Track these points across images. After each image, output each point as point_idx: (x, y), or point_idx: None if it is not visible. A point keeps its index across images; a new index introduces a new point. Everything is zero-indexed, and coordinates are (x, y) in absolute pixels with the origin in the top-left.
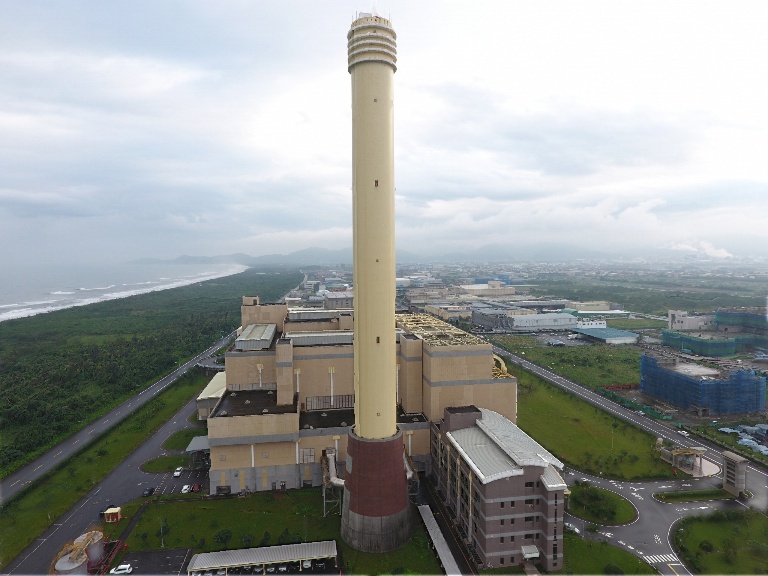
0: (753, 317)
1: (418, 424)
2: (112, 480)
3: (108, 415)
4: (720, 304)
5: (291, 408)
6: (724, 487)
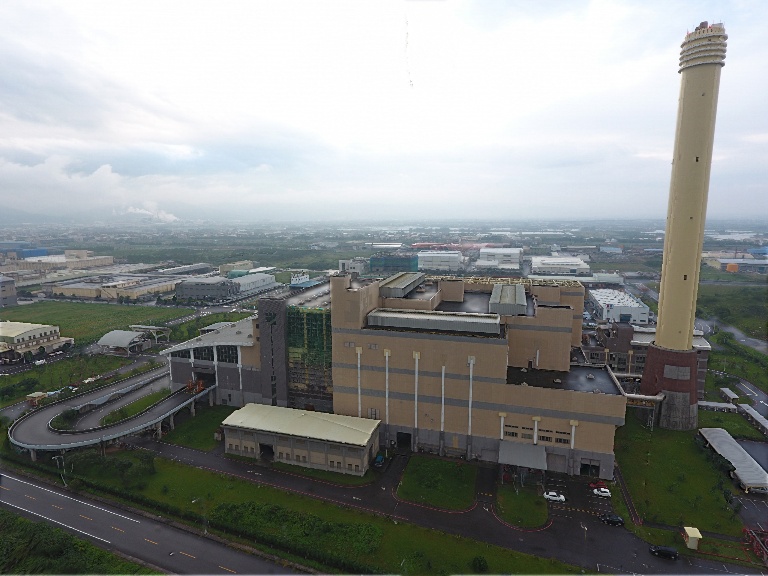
0: (391, 259)
1: None
2: (574, 553)
3: None
4: (292, 256)
5: (579, 368)
6: None
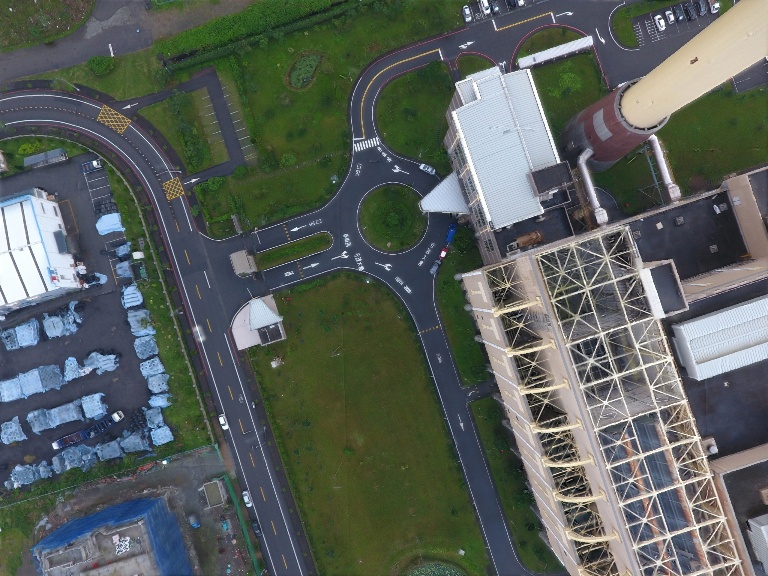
0: None
1: (590, 233)
2: None
3: None
4: None
5: (762, 204)
6: (256, 269)
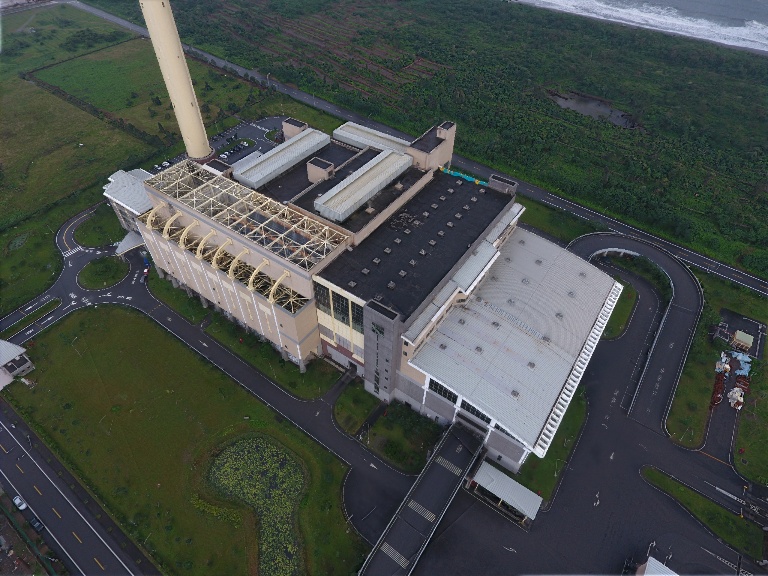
0: None
1: None
2: None
3: (494, 171)
4: None
5: None
6: None
